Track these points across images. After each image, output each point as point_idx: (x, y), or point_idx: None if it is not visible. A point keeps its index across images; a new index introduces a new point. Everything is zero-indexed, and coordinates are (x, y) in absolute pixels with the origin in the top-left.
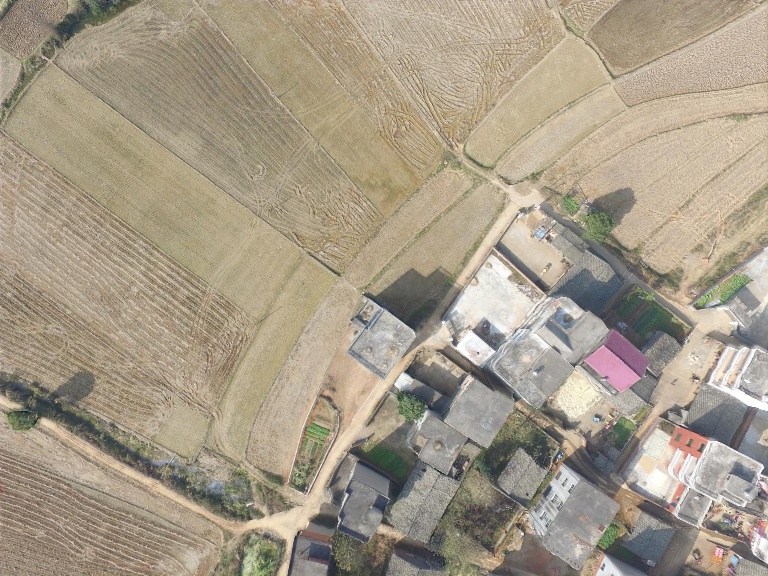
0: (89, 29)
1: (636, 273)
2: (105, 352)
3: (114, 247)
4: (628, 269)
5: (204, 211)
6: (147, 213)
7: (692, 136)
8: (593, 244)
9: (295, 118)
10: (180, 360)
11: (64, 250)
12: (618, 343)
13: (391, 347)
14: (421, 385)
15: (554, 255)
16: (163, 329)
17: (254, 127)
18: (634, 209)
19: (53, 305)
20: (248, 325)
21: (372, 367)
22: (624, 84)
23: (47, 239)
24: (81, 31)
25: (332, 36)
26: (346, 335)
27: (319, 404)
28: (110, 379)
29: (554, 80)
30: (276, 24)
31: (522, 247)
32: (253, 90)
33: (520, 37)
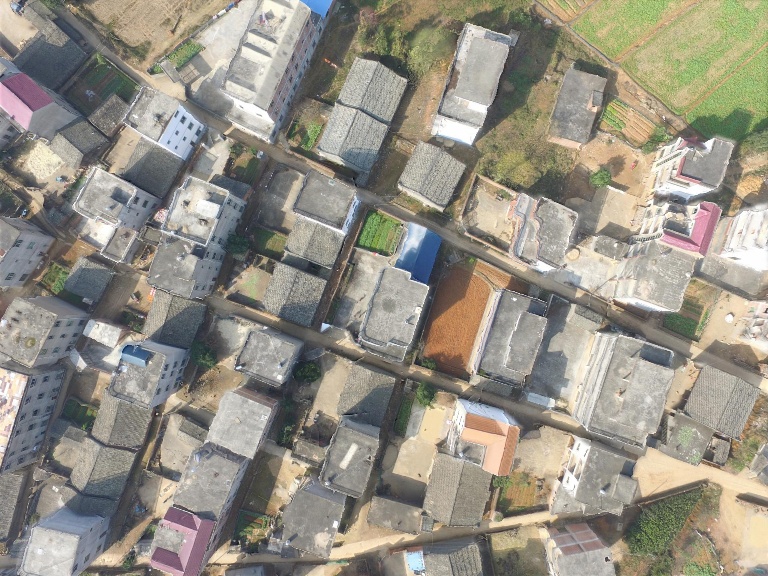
0: None
1: (108, 46)
2: None
3: None
4: (102, 42)
5: None
6: None
7: None
8: (71, 19)
9: None
10: None
11: None
12: (22, 83)
13: None
14: None
15: (35, 30)
16: None
17: None
18: None
19: None
20: None
21: None
22: None
23: None
24: None
25: None
26: None
27: None
28: None
29: None
30: None
31: (6, 23)
32: None
33: None
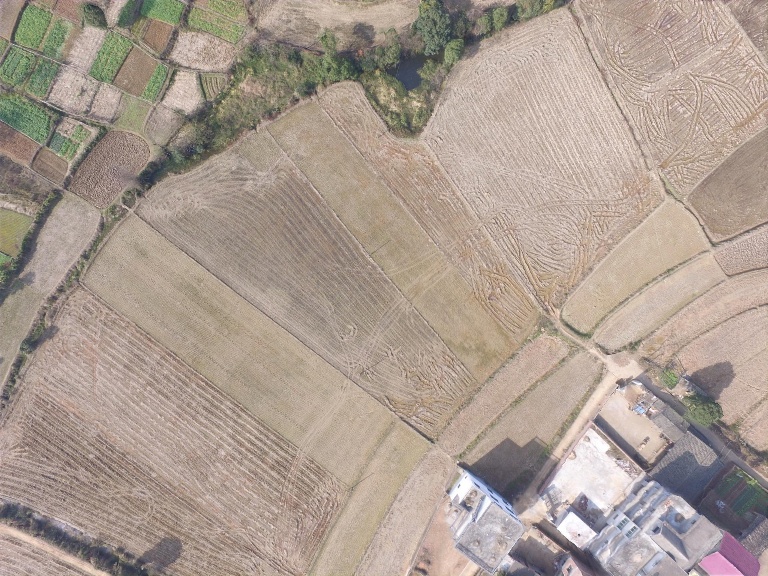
0: (172, 178)
1: (734, 450)
2: (192, 517)
3: (200, 408)
4: (726, 445)
5: (293, 372)
6: (234, 373)
7: None
8: None
9: (387, 277)
10: (269, 526)
11: (148, 411)
12: (730, 546)
13: (499, 541)
14: (522, 567)
15: (652, 429)
16: (252, 494)
17: (345, 285)
18: (733, 383)
19: (137, 468)
20: (339, 491)
21: (479, 561)
22: (724, 252)
23: (130, 399)
24: (163, 179)
25: (425, 192)
26: (441, 506)
27: (413, 575)
28: (198, 545)
29: (653, 245)
30: (367, 177)
31: (620, 419)
32: (344, 246)
33: (618, 198)
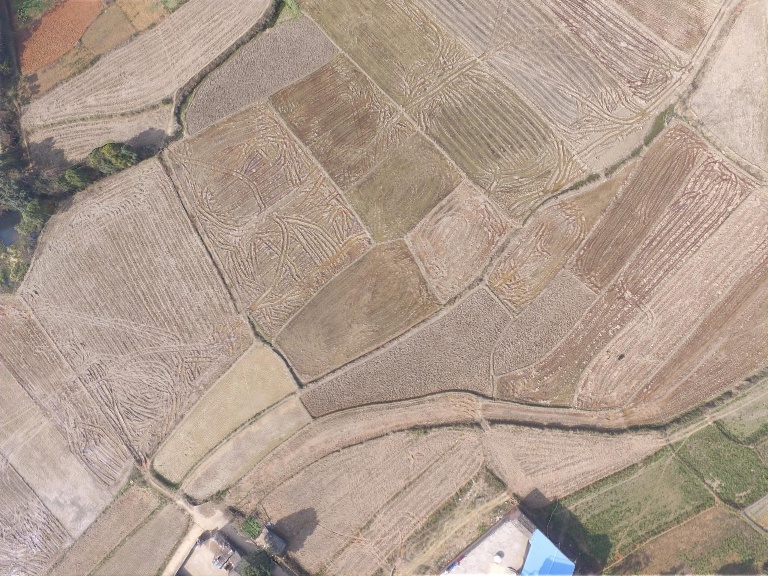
0: None
1: None
2: None
3: None
4: None
5: None
6: None
7: (374, 451)
8: (275, 569)
9: None
10: None
11: None
12: None
13: None
14: None
15: None
16: None
17: None
18: (317, 530)
19: None
20: None
21: None
22: (310, 394)
23: None
24: None
25: (22, 346)
26: None
27: None
28: None
29: (242, 390)
30: None
31: (205, 573)
32: None
33: (209, 343)
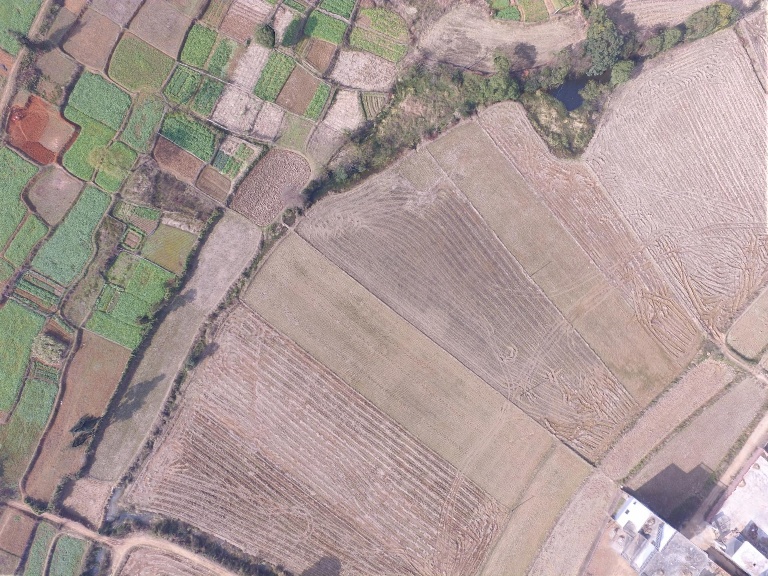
0: (332, 196)
1: None
2: (351, 536)
3: (359, 427)
4: None
5: (453, 393)
6: (393, 393)
7: None
8: None
9: (548, 298)
10: (429, 547)
11: (307, 429)
12: None
13: (683, 570)
14: None
15: None
16: (411, 514)
17: (505, 306)
18: None
19: (296, 486)
20: (499, 513)
21: None
22: None
23: (290, 417)
24: (323, 198)
25: (587, 213)
26: (606, 531)
27: None
28: (357, 565)
29: None
30: (528, 198)
31: None
32: (504, 267)
33: None
